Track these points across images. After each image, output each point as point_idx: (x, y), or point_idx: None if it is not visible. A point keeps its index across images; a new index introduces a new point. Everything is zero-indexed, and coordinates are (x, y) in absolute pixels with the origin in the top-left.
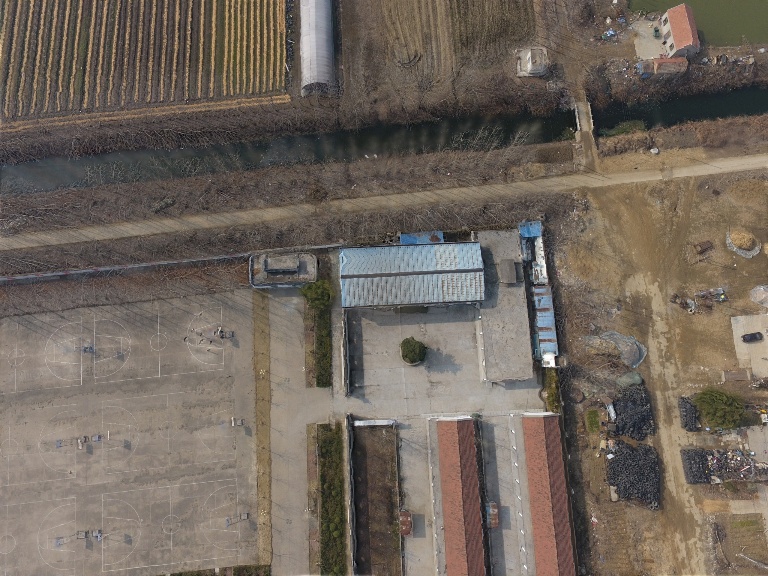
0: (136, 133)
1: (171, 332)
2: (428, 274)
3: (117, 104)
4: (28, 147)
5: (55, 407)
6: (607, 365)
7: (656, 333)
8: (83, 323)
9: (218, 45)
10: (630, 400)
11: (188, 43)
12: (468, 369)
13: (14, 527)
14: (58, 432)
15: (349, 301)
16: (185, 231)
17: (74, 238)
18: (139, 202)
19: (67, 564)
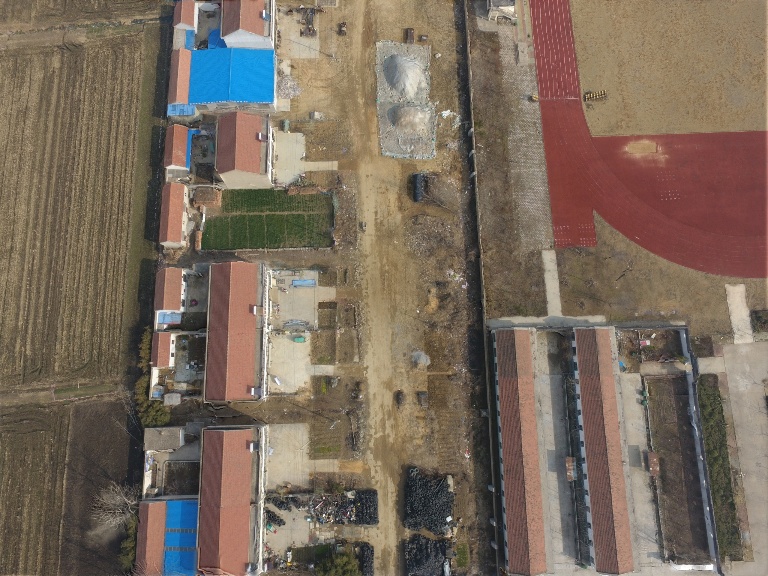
0: None
1: None
2: None
3: None
4: None
5: None
6: None
7: None
8: None
9: None
10: None
11: None
12: None
13: None
14: None
15: None
16: None
17: None
18: None
19: None
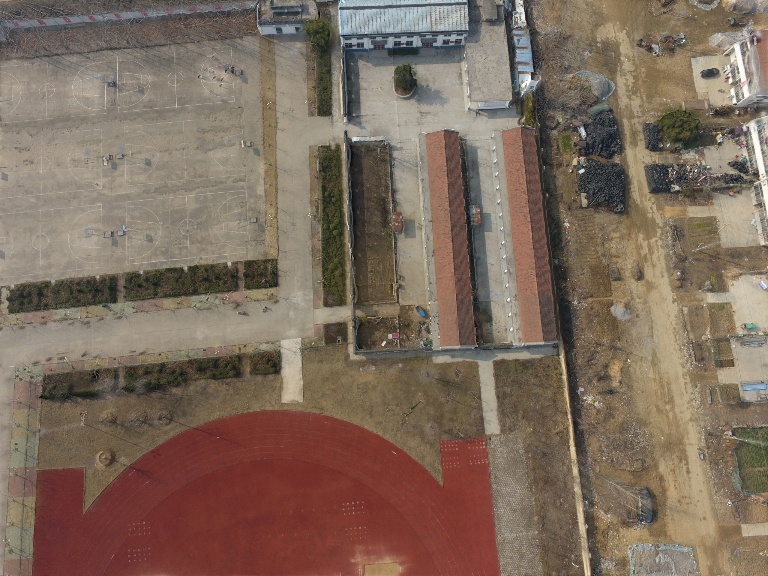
0: None
1: (186, 71)
2: (418, 6)
3: None
4: None
5: (82, 131)
6: (579, 96)
7: (624, 72)
8: (107, 63)
9: None
10: (599, 123)
11: None
12: (454, 102)
13: (47, 228)
14: (85, 152)
15: (347, 30)
16: None
17: None
18: None
19: (95, 258)
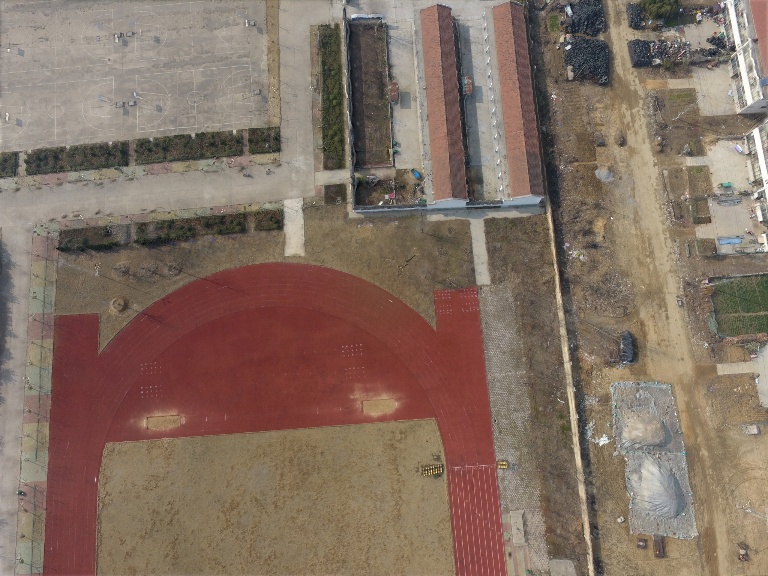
0: None
1: None
2: None
3: None
4: None
5: (95, 11)
6: None
7: None
8: None
9: None
10: (585, 3)
11: None
12: None
13: (62, 99)
14: (98, 30)
15: None
16: None
17: None
18: None
19: (107, 126)
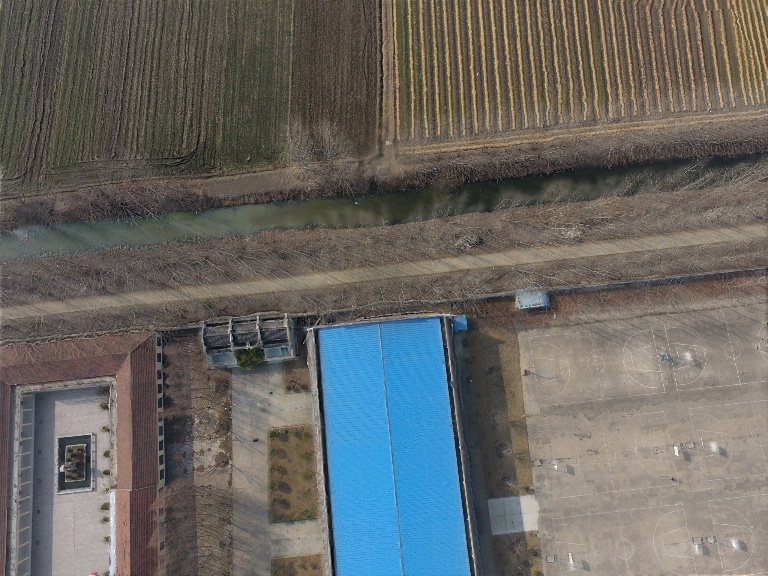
0: (670, 143)
1: (743, 340)
2: None
3: (642, 114)
4: (567, 156)
5: (644, 414)
6: None
7: None
8: (654, 331)
9: (731, 55)
10: None
11: (701, 53)
12: None
13: (629, 533)
14: (652, 439)
15: None
16: (743, 240)
17: (637, 247)
18: (690, 211)
19: (688, 570)
